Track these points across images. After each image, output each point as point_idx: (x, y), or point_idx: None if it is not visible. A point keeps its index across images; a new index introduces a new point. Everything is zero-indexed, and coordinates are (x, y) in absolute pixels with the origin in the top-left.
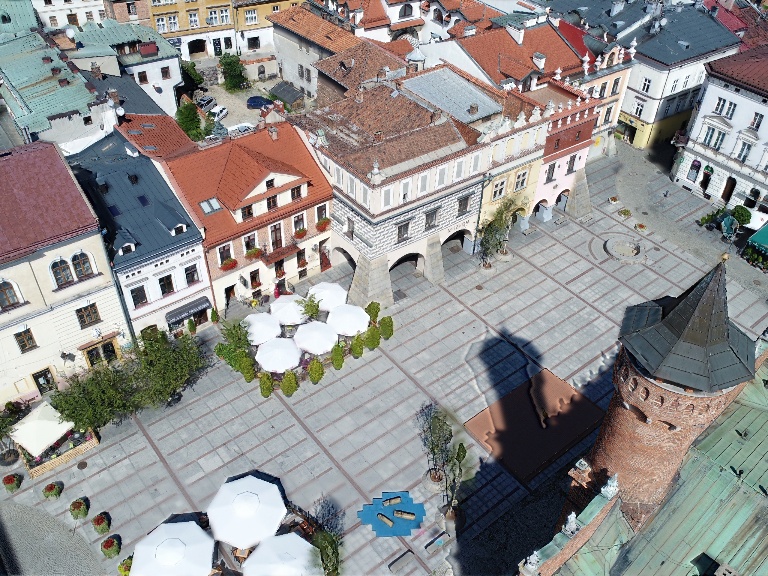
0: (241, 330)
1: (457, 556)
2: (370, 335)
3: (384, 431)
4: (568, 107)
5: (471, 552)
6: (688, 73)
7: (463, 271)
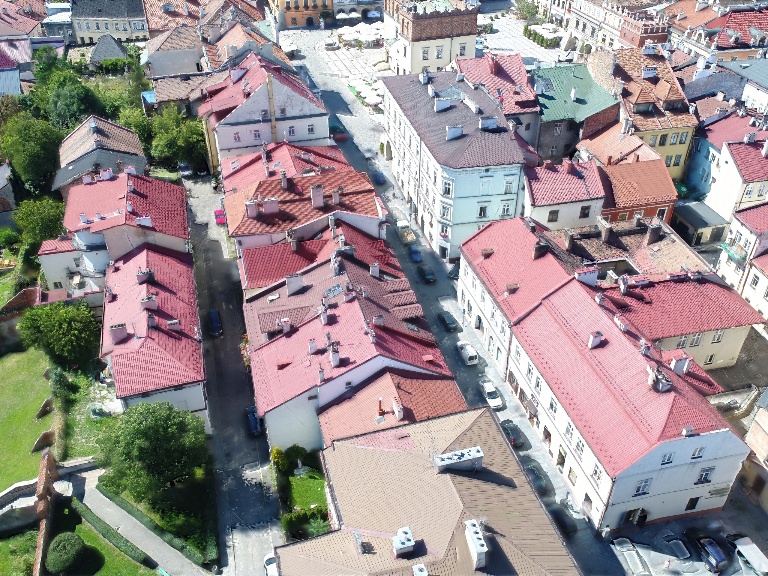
0: None
1: None
2: None
3: (506, 44)
4: None
5: None
6: None
7: None
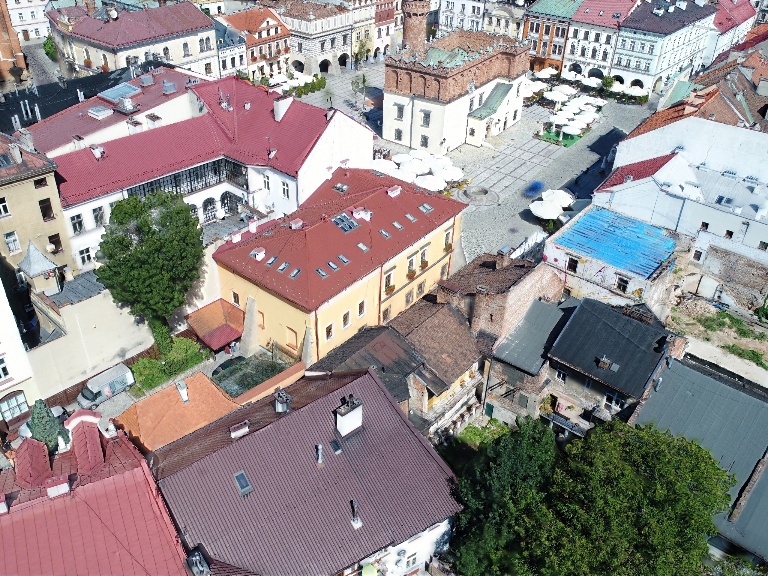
0: (267, 78)
1: (368, 123)
2: (318, 82)
3: None
4: (382, 0)
5: (373, 122)
6: (436, 1)
7: (349, 73)
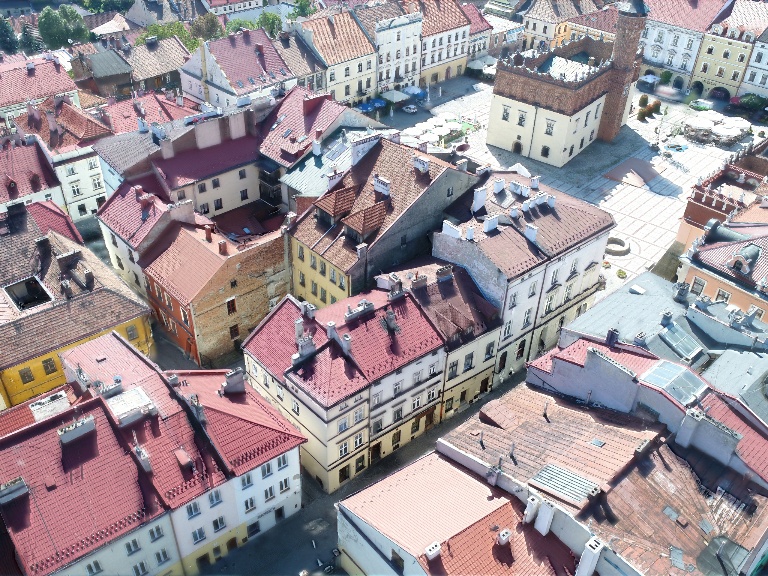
0: None
1: None
2: None
3: None
4: (714, 175)
5: None
6: None
7: None
